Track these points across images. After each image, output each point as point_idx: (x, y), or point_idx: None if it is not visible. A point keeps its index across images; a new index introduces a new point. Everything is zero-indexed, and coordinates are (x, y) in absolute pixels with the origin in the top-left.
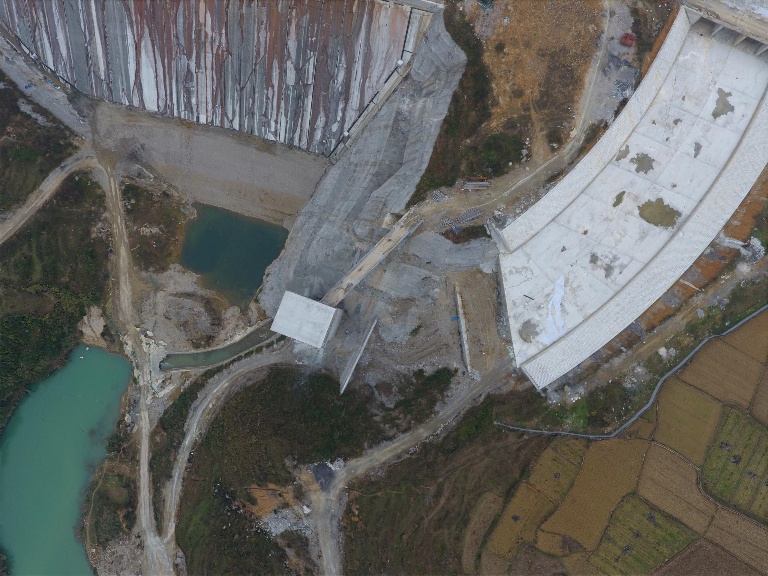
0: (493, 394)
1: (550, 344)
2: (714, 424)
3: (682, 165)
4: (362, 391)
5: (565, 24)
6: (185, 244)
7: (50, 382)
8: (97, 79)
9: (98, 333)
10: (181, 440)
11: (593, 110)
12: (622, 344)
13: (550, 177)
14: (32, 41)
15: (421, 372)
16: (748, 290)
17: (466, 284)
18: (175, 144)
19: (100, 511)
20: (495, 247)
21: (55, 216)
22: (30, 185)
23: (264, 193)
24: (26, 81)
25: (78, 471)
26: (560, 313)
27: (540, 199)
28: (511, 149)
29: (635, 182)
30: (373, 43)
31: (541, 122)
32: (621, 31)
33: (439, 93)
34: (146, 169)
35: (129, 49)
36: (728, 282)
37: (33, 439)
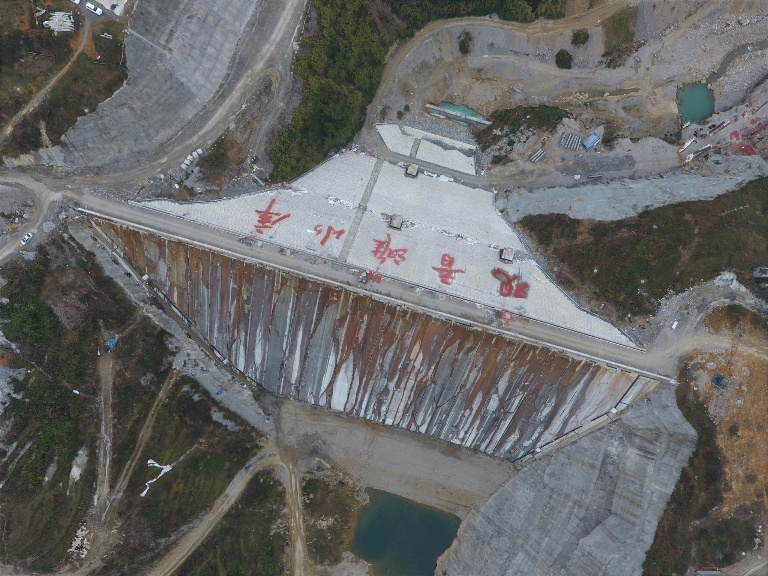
0: None
1: None
2: None
3: None
4: None
5: None
6: (356, 530)
7: None
8: (286, 382)
9: None
10: None
11: None
12: None
13: None
14: (227, 350)
15: None
16: None
17: None
18: (358, 442)
19: None
20: None
21: (240, 521)
22: (217, 491)
23: (442, 487)
24: (218, 387)
25: None
26: None
27: None
28: (743, 536)
29: None
30: (589, 393)
31: None
32: None
33: (660, 457)
34: (324, 460)
35: (328, 367)
36: None
37: None
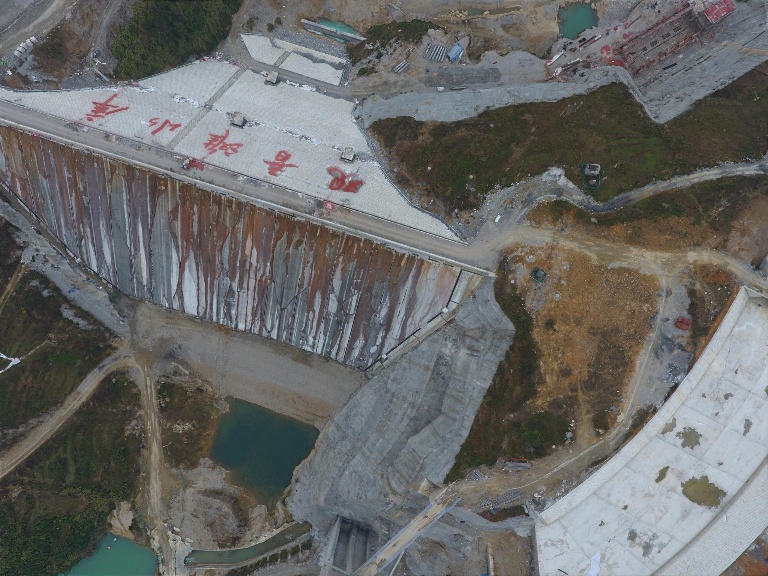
0: None
1: None
2: None
3: (730, 442)
4: None
5: (619, 302)
6: (216, 438)
7: (77, 567)
8: (139, 284)
9: (126, 526)
10: None
11: (642, 394)
12: None
13: (594, 462)
14: (78, 248)
15: None
16: None
17: (499, 547)
18: (212, 347)
19: None
20: (532, 521)
21: (91, 418)
22: (68, 388)
23: (297, 396)
24: (70, 285)
25: None
26: None
27: (582, 482)
28: (555, 430)
29: (680, 457)
30: (419, 291)
31: (588, 404)
32: (677, 312)
33: (484, 354)
34: (182, 366)
35: (173, 266)
36: None
37: None
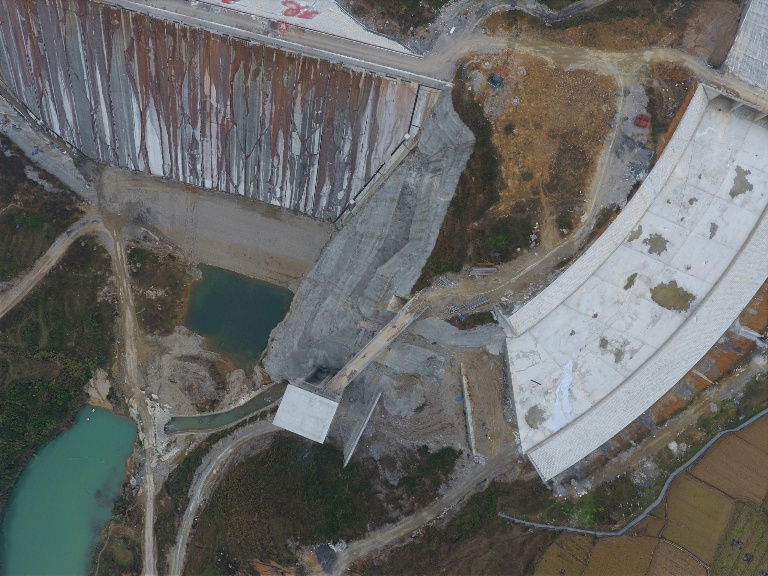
0: (498, 482)
1: (557, 430)
2: (725, 521)
3: (697, 246)
4: (366, 464)
5: (577, 104)
6: (190, 306)
7: (57, 442)
8: (103, 145)
9: (104, 396)
10: (185, 506)
11: (605, 194)
12: (631, 437)
13: (559, 263)
14: (38, 108)
15: (425, 449)
16: (764, 383)
17: (472, 366)
18: (180, 208)
19: (105, 573)
20: (502, 331)
21: (61, 282)
22: (37, 251)
23: (269, 257)
24: (33, 148)
25: (84, 532)
26: (568, 399)
27: (549, 285)
28: (519, 234)
29: (648, 264)
30: (380, 117)
31: (551, 206)
32: (635, 111)
33: (446, 171)
34: (152, 232)
35: (134, 117)
36: (743, 375)
37: (40, 499)
